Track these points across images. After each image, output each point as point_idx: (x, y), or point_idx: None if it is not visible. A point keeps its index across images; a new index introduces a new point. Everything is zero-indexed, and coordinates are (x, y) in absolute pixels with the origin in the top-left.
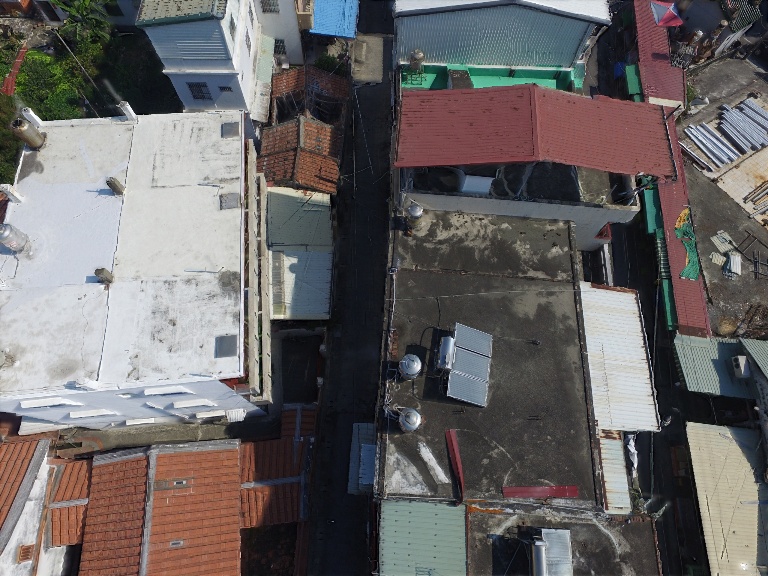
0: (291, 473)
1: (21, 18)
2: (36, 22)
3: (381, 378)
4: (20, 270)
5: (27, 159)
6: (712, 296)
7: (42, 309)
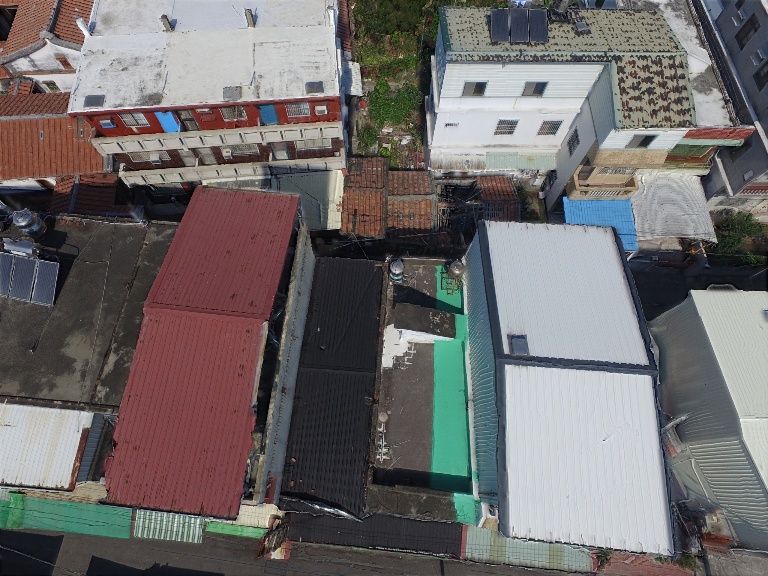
0: (79, 208)
1: None
2: None
3: None
4: None
5: None
6: None
7: (157, 2)
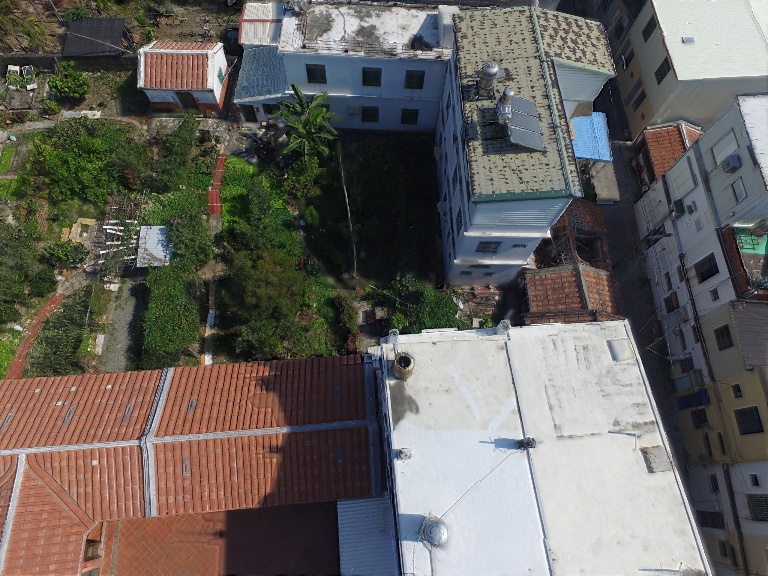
0: None
1: (215, 119)
2: (231, 123)
3: None
4: (437, 566)
5: (394, 392)
6: None
7: None
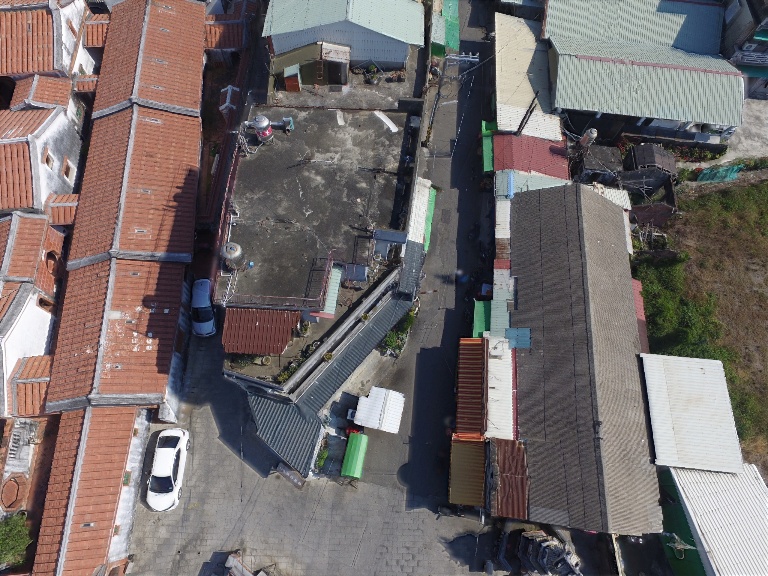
0: None
1: None
2: None
3: None
4: None
5: None
6: None
7: None
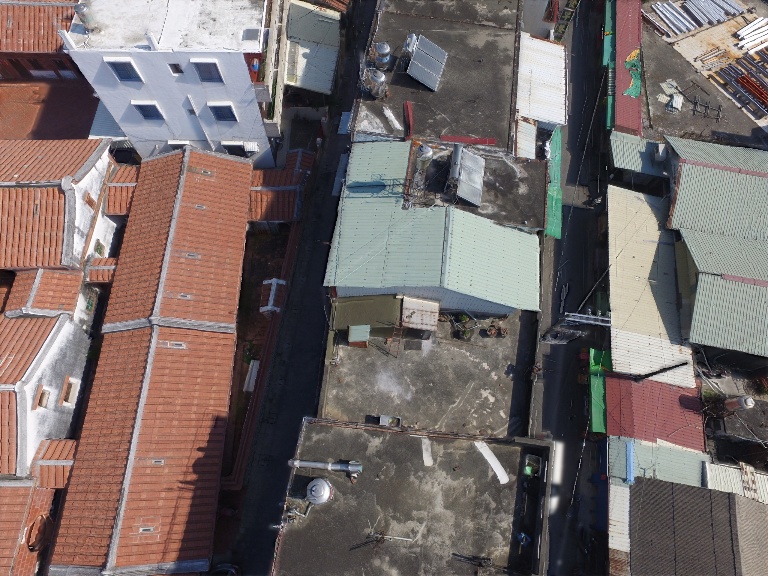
0: None
1: None
2: None
3: (361, 70)
4: None
5: None
6: (653, 124)
7: (121, 5)
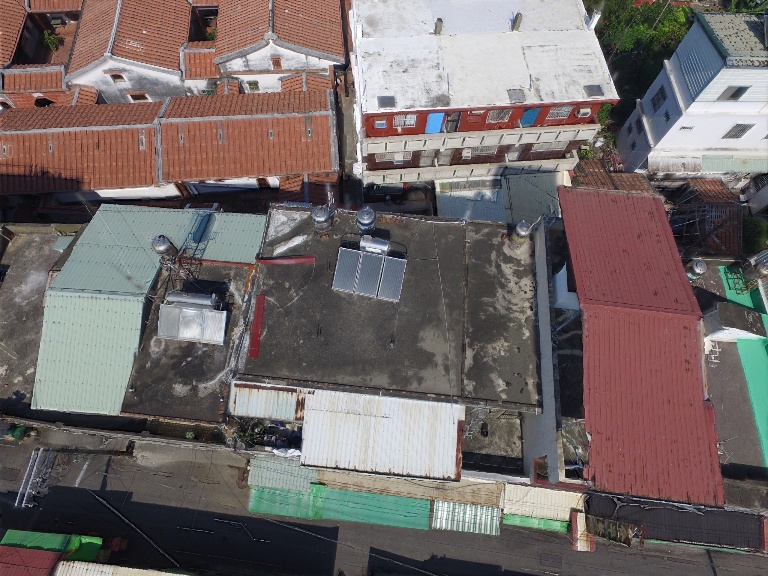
0: None
1: None
2: (722, 4)
3: None
4: None
5: None
6: None
7: (414, 5)
